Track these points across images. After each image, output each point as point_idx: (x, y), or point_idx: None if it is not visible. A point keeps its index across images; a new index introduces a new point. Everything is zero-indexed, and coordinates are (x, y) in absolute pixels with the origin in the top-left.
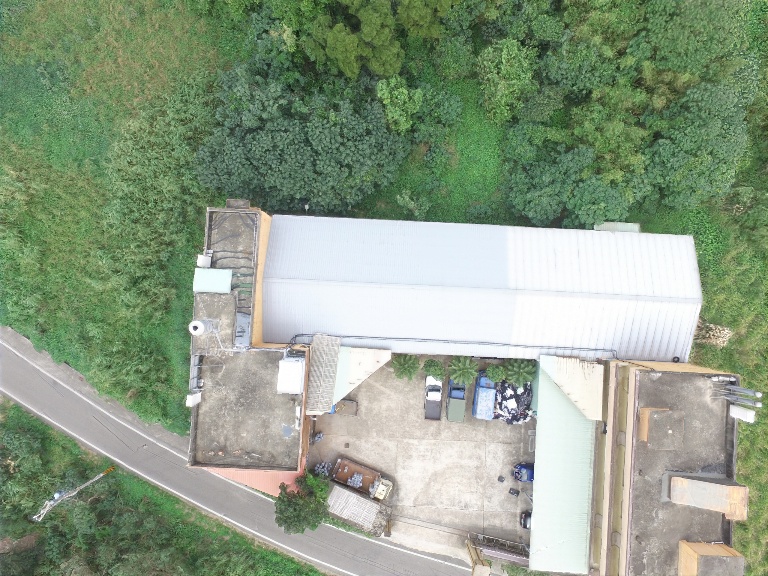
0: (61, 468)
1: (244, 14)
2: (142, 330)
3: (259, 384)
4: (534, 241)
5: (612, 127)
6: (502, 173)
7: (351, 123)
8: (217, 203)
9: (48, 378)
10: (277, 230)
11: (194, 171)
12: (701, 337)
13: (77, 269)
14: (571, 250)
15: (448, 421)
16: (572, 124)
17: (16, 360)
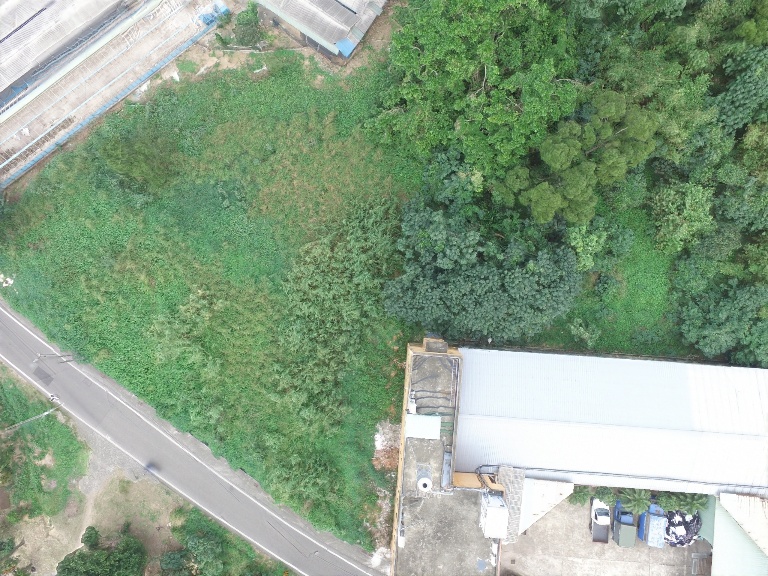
0: (238, 570)
1: (429, 153)
2: (315, 441)
3: (455, 519)
4: (714, 380)
5: None
6: (669, 301)
7: (546, 271)
8: (389, 323)
9: (225, 483)
10: (464, 364)
11: (373, 296)
12: None
13: (252, 380)
14: (752, 390)
15: (612, 541)
16: (743, 257)
17: (196, 465)
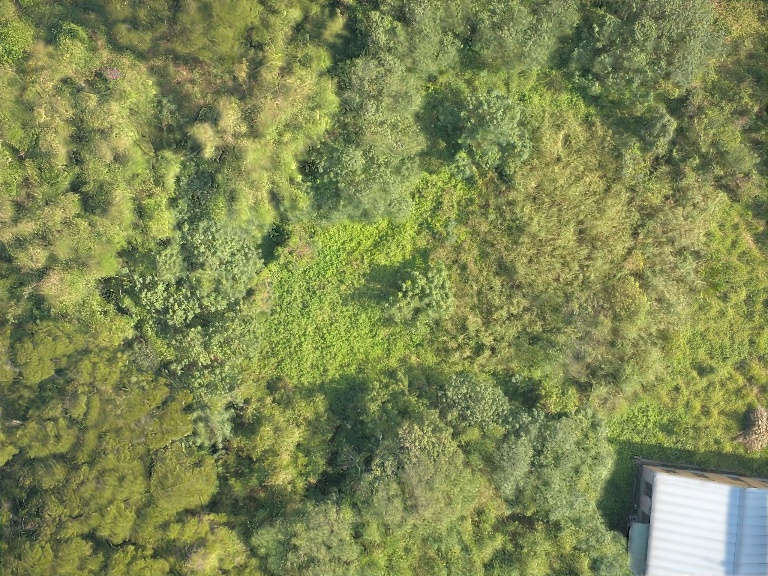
0: None
1: None
2: None
3: None
4: None
5: (531, 572)
6: None
7: None
8: None
9: None
10: None
11: None
12: (761, 443)
13: None
14: None
15: None
16: None
17: None
